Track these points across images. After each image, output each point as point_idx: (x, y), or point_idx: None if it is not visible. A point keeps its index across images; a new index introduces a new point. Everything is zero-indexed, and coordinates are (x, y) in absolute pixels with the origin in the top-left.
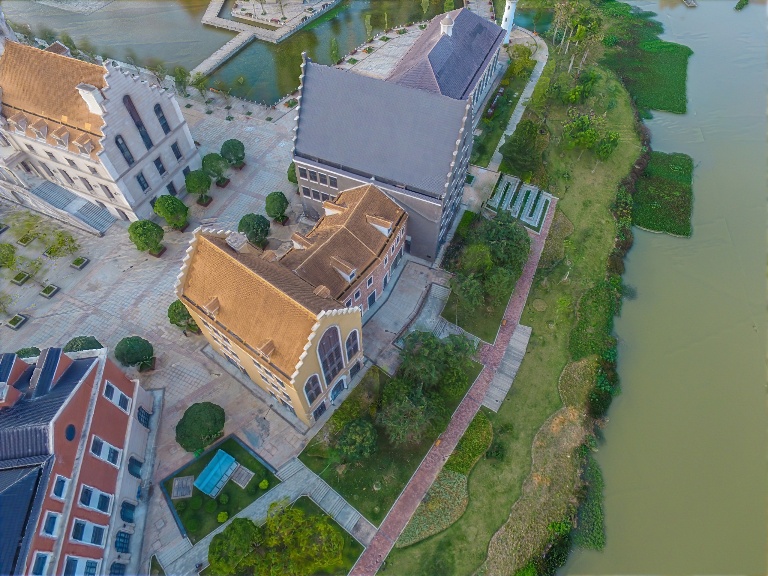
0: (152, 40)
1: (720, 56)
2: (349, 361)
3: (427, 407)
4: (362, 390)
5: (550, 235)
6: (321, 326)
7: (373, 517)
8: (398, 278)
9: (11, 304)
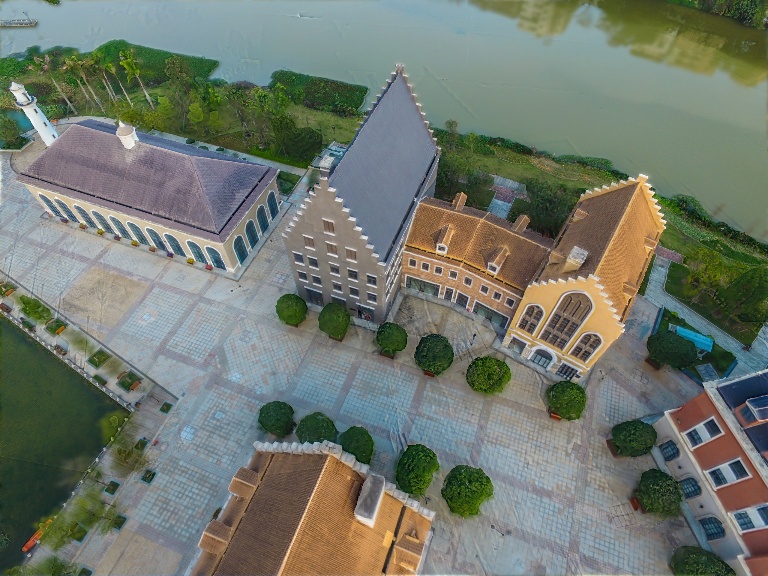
0: None
1: (135, 28)
2: None
3: None
4: None
5: None
6: None
7: None
8: None
9: None
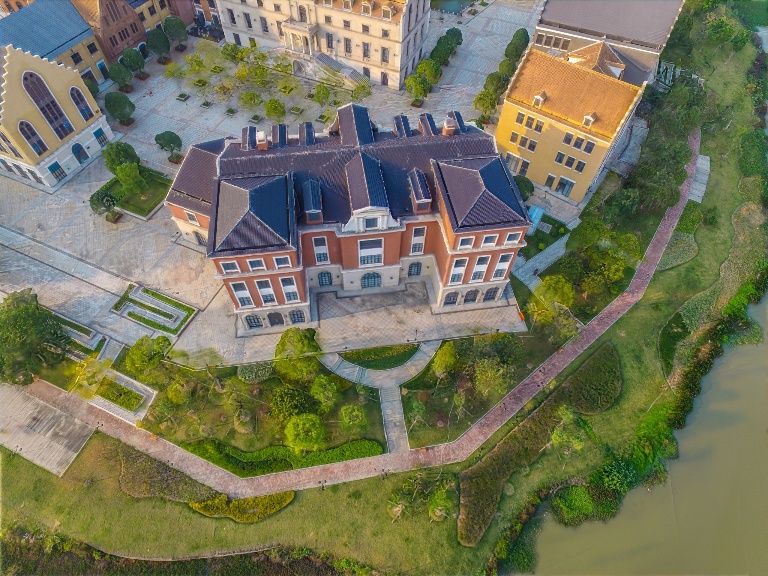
0: None
1: None
2: None
3: None
4: (608, 183)
5: None
6: None
7: None
8: None
9: None
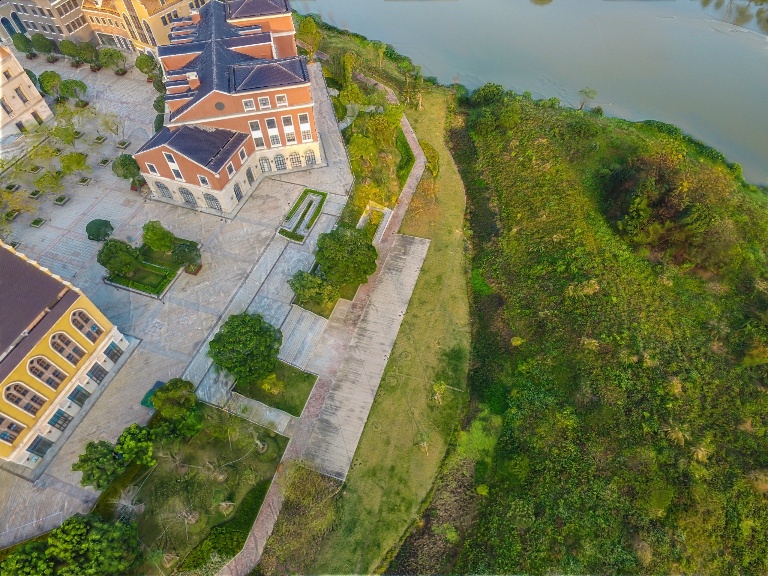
0: None
1: None
2: None
3: None
4: None
5: None
6: None
7: None
8: None
9: (105, 153)
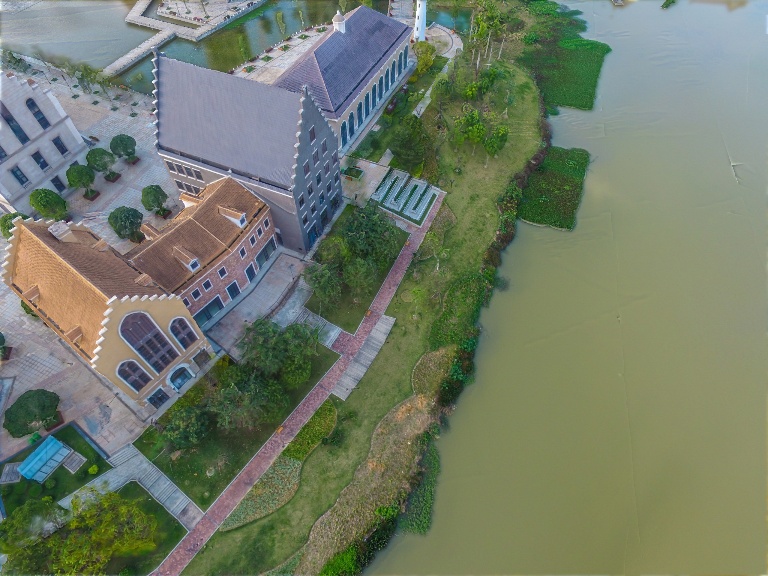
0: (73, 38)
1: (637, 53)
2: (186, 349)
3: (255, 393)
4: None
5: (431, 228)
6: (115, 311)
7: (202, 502)
8: (268, 270)
9: None
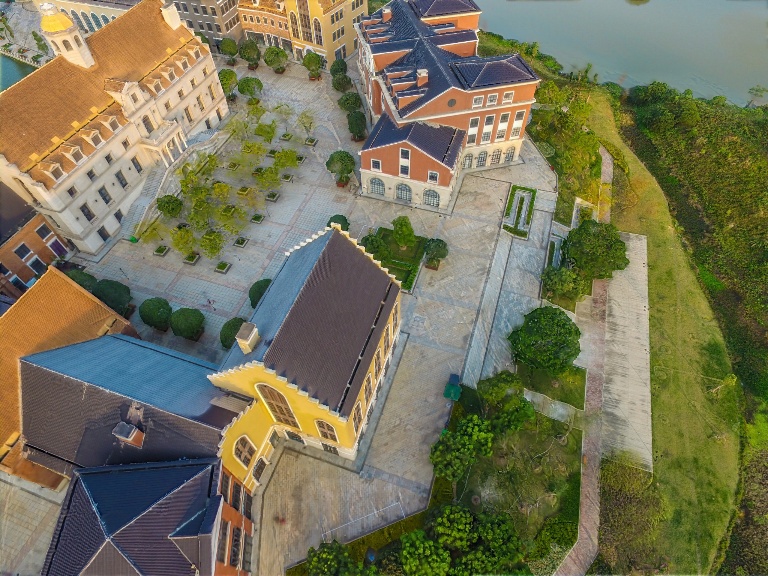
0: None
1: None
2: None
3: None
4: None
5: None
6: None
7: None
8: None
9: (296, 150)
